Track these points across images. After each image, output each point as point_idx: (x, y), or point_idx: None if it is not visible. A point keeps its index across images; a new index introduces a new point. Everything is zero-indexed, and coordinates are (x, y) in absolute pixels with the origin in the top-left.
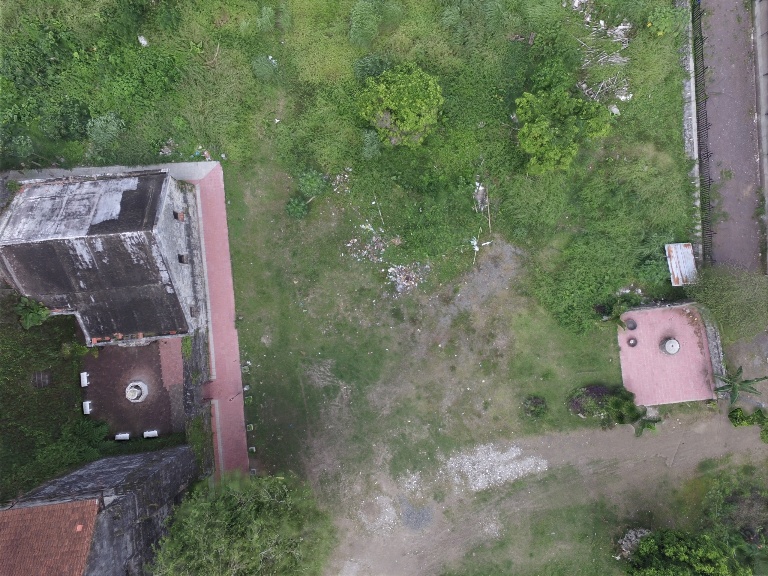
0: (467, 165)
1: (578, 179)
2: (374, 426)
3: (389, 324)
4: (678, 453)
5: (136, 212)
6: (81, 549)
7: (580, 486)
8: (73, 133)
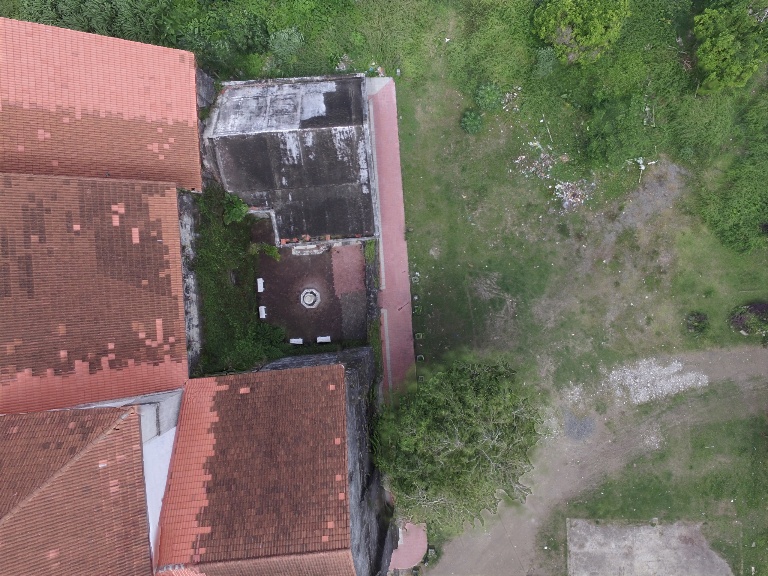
0: (635, 85)
1: (743, 102)
2: (539, 338)
3: (555, 239)
4: None
5: (342, 110)
6: (339, 405)
7: (740, 402)
8: (256, 44)
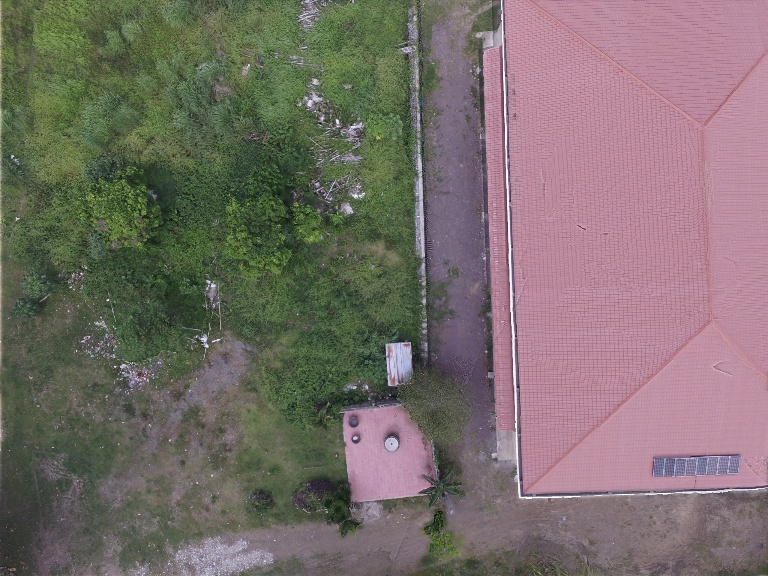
0: (197, 264)
1: (308, 277)
2: (105, 519)
3: (121, 419)
4: (402, 547)
5: None
6: None
7: None
8: None
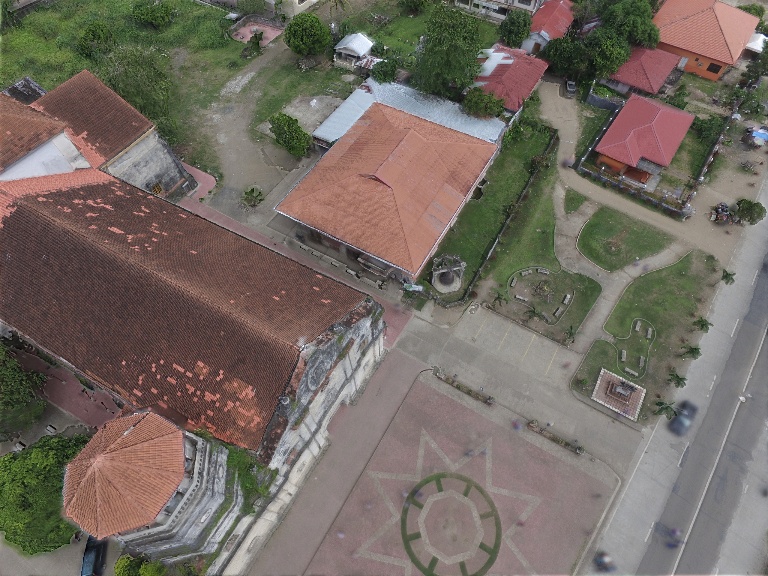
0: None
1: None
2: (182, 105)
3: None
4: None
5: None
6: None
7: None
8: None
